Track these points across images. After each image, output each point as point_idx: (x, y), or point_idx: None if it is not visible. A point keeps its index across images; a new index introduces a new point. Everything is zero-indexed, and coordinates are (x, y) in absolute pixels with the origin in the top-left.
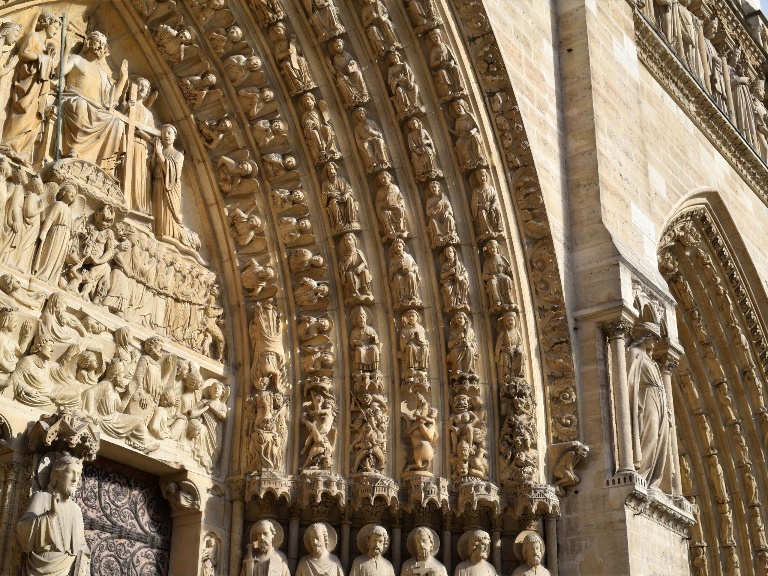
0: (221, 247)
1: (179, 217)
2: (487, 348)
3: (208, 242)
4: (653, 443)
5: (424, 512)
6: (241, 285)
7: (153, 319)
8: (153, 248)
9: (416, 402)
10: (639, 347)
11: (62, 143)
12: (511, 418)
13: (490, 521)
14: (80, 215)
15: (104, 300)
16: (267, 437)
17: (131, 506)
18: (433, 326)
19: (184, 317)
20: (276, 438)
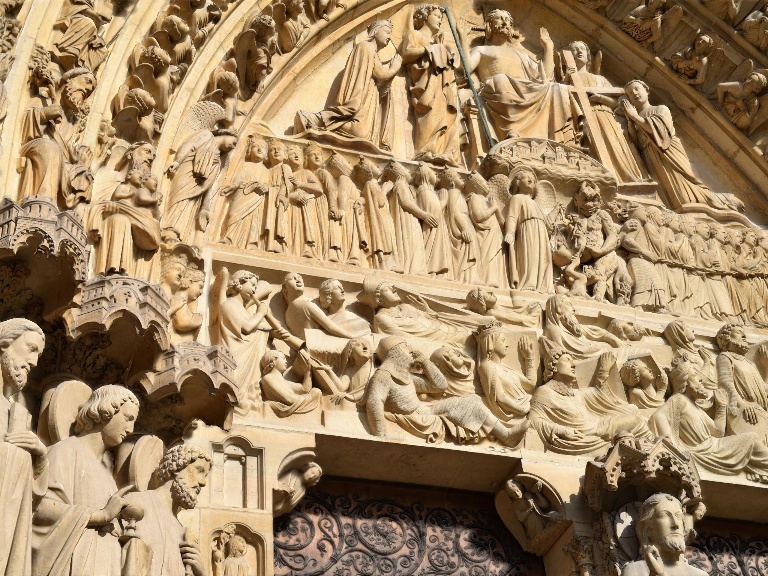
0: None
1: None
2: None
3: (753, 202)
4: None
5: None
6: None
7: (715, 308)
8: (674, 221)
9: None
10: None
11: (495, 133)
12: None
13: None
14: (553, 208)
15: (632, 301)
16: None
17: None
18: None
19: (761, 296)
20: None
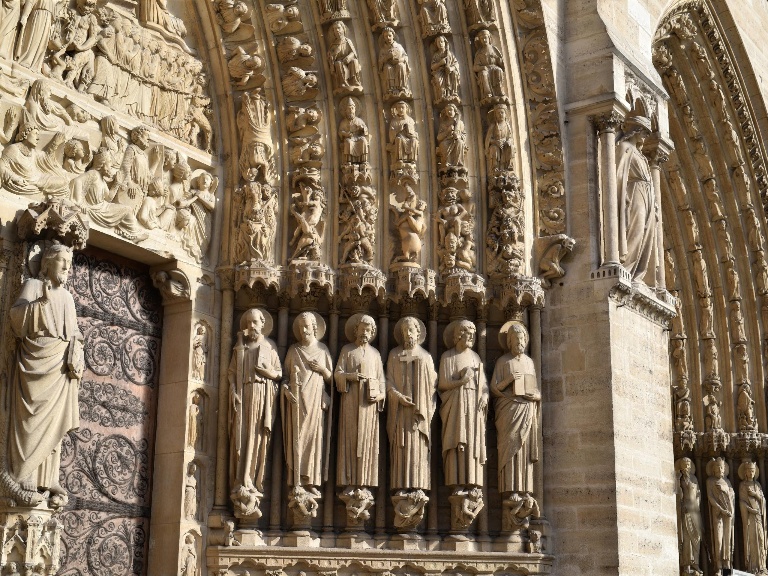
0: (207, 34)
1: (163, 3)
2: (477, 141)
3: (194, 29)
4: (639, 237)
5: (411, 302)
6: (228, 74)
7: (139, 108)
8: (137, 35)
9: (405, 194)
10: (629, 141)
11: None
12: (499, 211)
13: (476, 312)
14: None
15: (89, 88)
16: (256, 228)
17: (122, 294)
18: (423, 118)
19: (171, 106)
20: (265, 229)
